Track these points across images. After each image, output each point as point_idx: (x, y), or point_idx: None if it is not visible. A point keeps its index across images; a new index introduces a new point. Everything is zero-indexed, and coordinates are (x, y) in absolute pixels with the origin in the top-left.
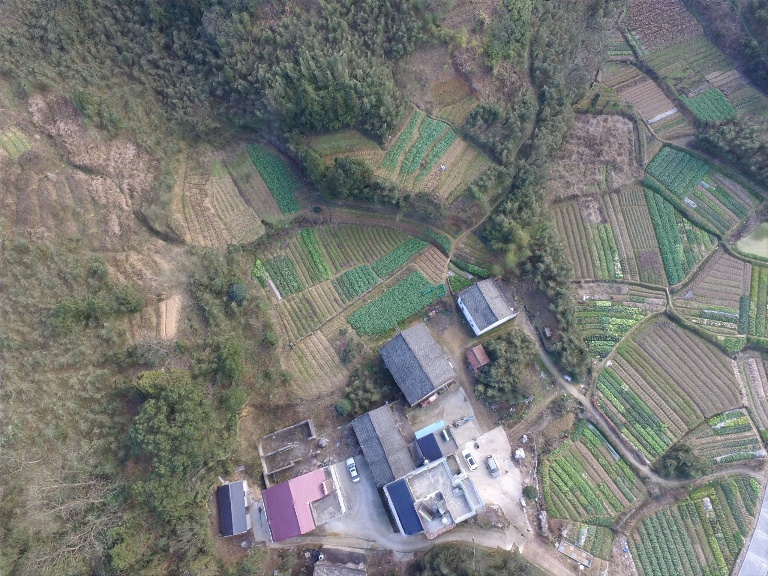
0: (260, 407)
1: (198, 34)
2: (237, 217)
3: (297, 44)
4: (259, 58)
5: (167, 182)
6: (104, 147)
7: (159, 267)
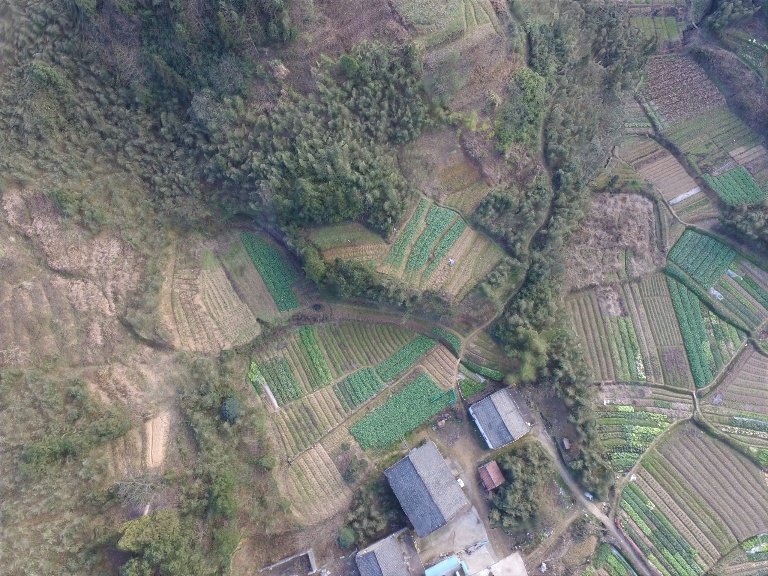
0: (256, 536)
1: (188, 115)
2: (230, 315)
3: (294, 131)
4: (253, 144)
5: (154, 284)
6: (85, 247)
7: (145, 380)
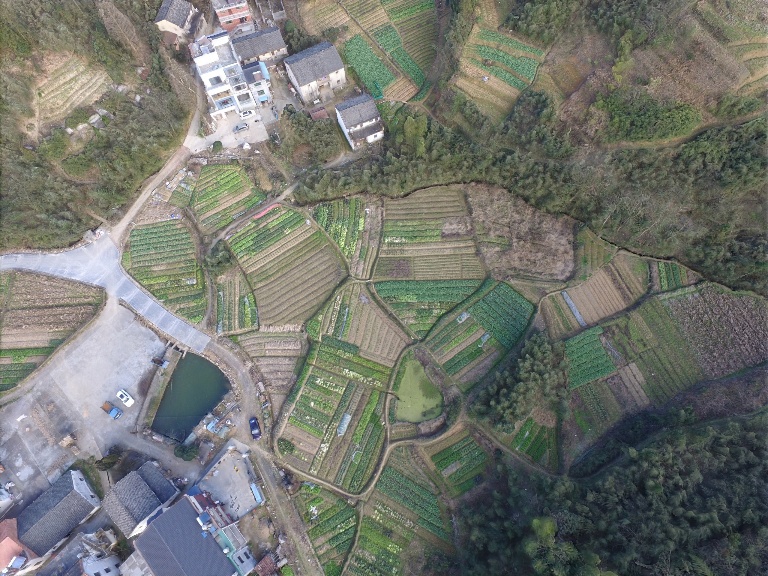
0: None
1: None
2: None
3: None
4: None
5: None
6: None
7: None
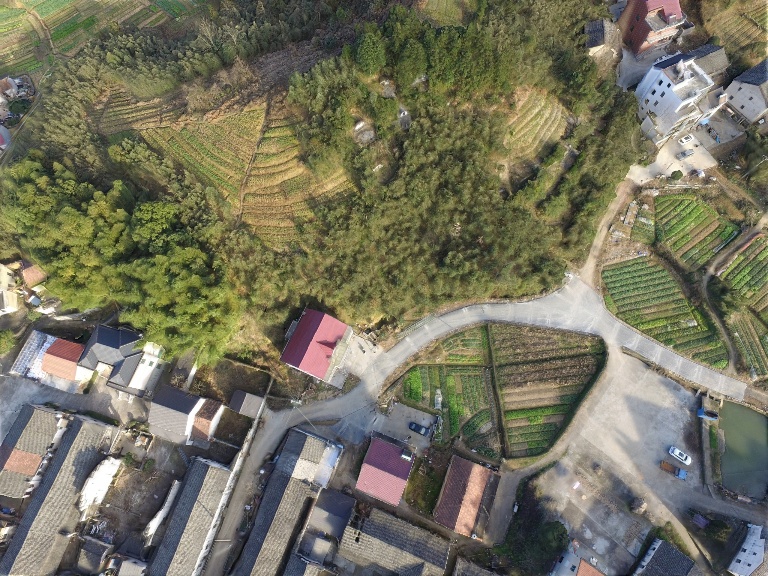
0: None
1: None
2: None
3: None
4: None
5: None
6: None
7: None
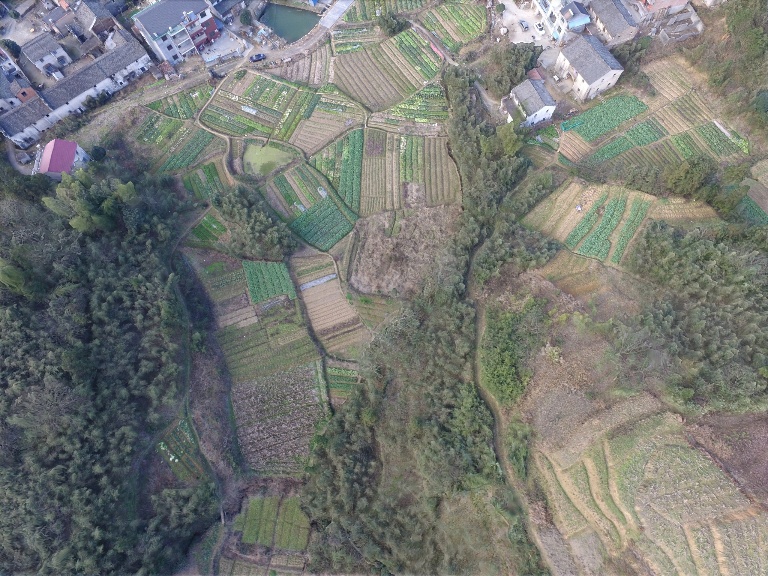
0: None
1: None
2: None
3: None
4: None
5: None
6: None
7: None
